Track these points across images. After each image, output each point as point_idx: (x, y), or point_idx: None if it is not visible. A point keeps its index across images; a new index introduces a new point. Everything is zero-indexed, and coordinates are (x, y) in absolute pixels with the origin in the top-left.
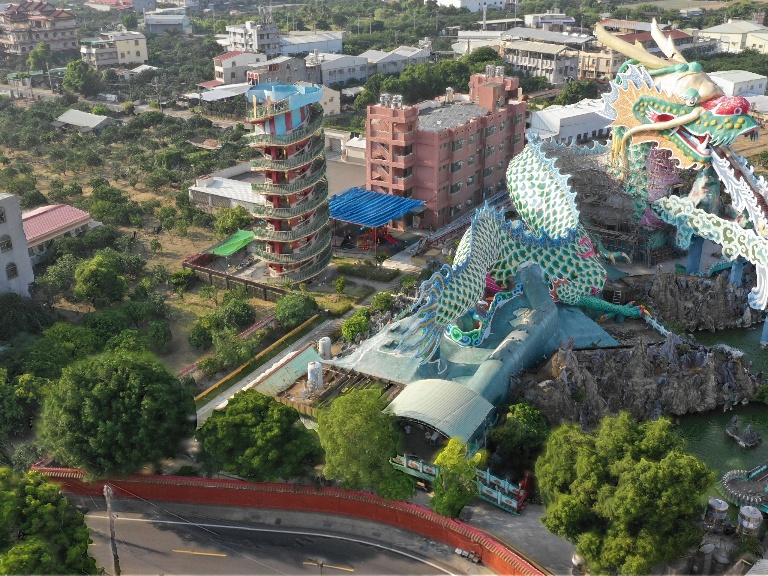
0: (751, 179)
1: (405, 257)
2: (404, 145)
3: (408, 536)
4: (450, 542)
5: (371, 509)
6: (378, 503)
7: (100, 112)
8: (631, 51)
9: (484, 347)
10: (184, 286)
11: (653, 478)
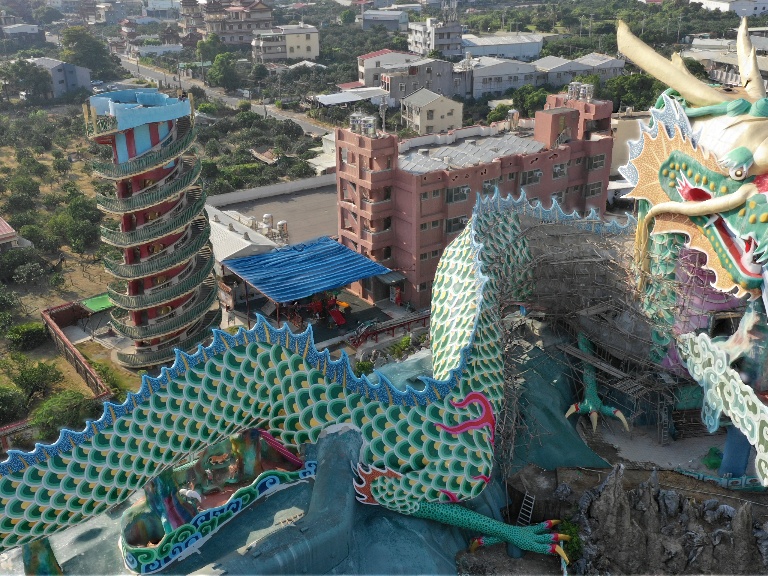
0: None
1: None
2: (370, 188)
3: None
4: None
5: None
6: None
7: (206, 109)
8: (663, 72)
9: None
10: (19, 345)
11: None
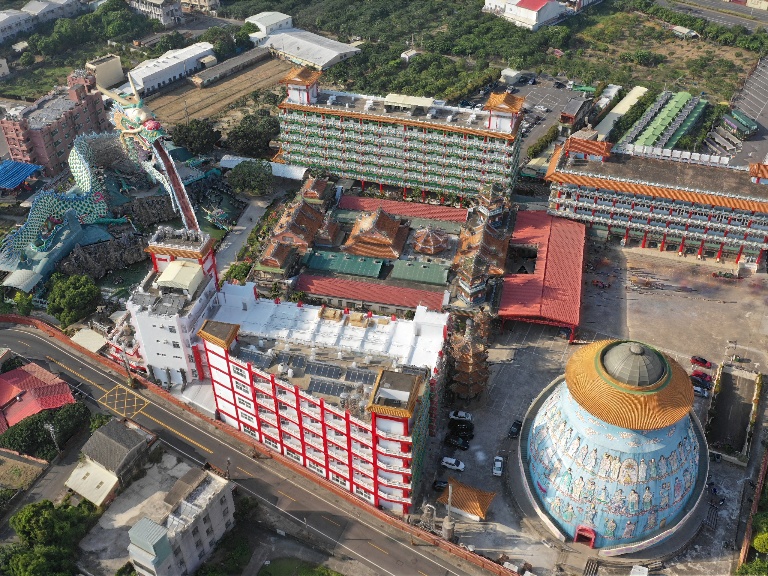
0: (168, 156)
1: (34, 198)
2: (23, 139)
3: (15, 324)
4: (28, 324)
5: (1, 318)
6: (2, 316)
7: None
8: (113, 97)
9: (47, 251)
10: None
11: (73, 295)
